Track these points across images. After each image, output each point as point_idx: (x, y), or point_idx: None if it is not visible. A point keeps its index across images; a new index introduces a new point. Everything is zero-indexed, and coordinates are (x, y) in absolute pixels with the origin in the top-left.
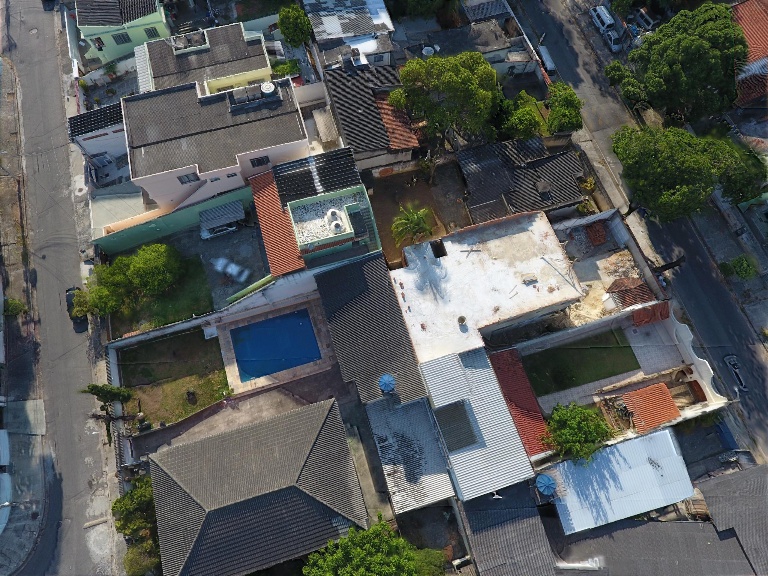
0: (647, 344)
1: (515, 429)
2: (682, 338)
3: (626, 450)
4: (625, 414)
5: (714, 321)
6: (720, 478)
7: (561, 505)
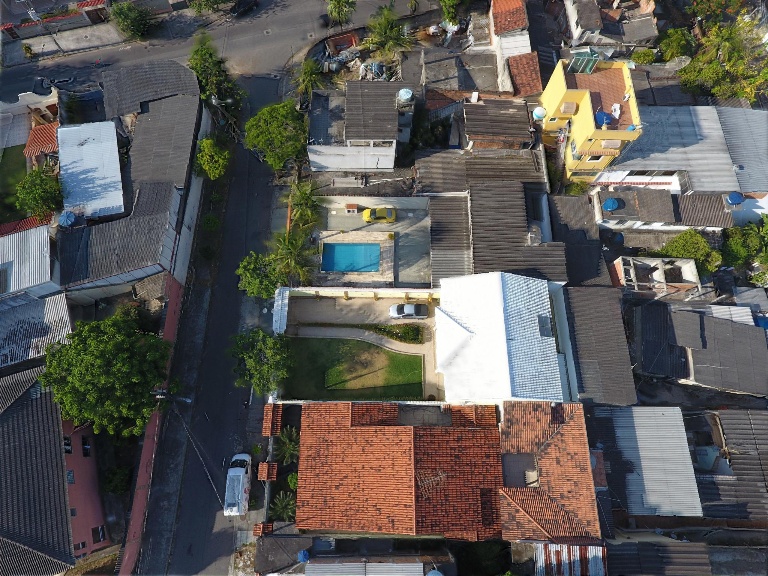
0: (6, 136)
1: (7, 237)
2: (3, 109)
3: (67, 160)
4: (57, 160)
5: (11, 88)
6: (105, 103)
7: (100, 212)
